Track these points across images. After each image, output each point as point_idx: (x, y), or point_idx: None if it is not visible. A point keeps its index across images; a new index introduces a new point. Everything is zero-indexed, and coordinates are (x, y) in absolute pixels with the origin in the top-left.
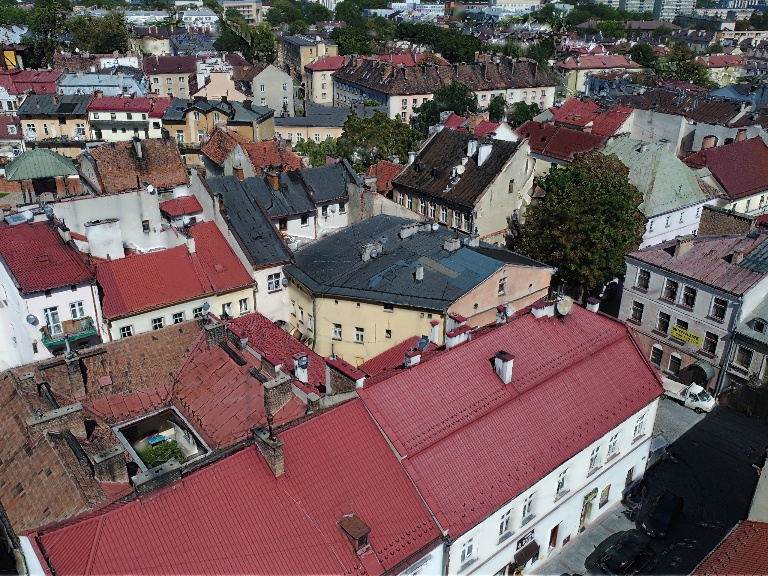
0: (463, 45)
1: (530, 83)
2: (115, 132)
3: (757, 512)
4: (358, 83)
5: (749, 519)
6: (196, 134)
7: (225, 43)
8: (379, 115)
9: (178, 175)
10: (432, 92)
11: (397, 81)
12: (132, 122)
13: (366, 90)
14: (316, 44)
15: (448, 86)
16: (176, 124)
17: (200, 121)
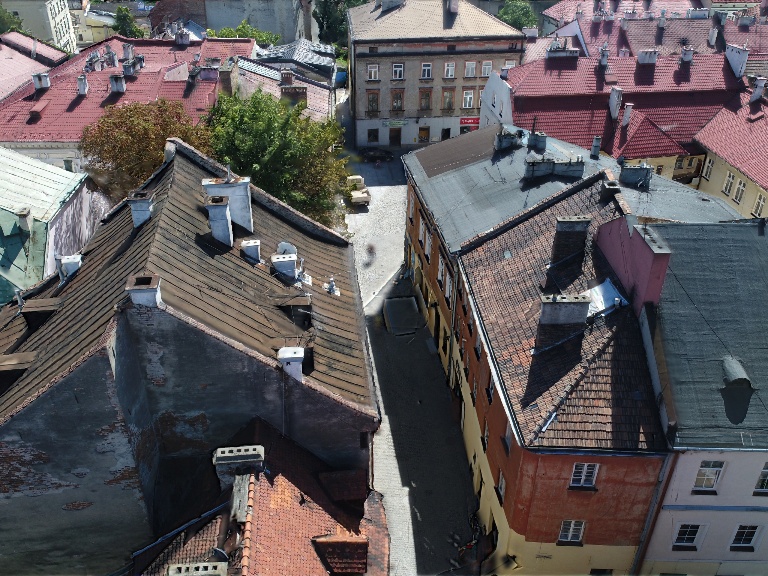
0: None
1: None
2: None
3: None
4: None
5: None
6: None
7: None
8: None
9: None
10: None
11: None
12: None
13: None
14: None
15: None
16: None
17: None
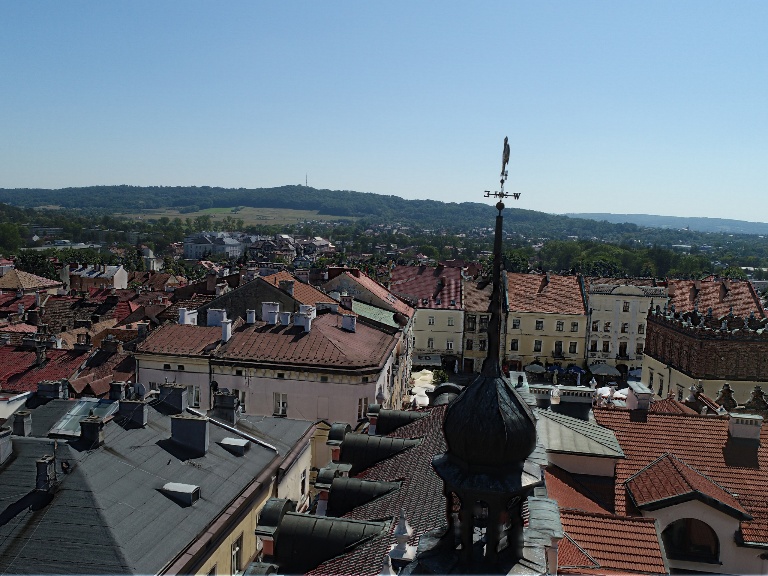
0: None
1: None
2: None
3: None
4: None
5: None
6: None
7: None
8: None
9: None
10: None
11: None
12: None
13: None
14: None
15: None
16: None
17: None
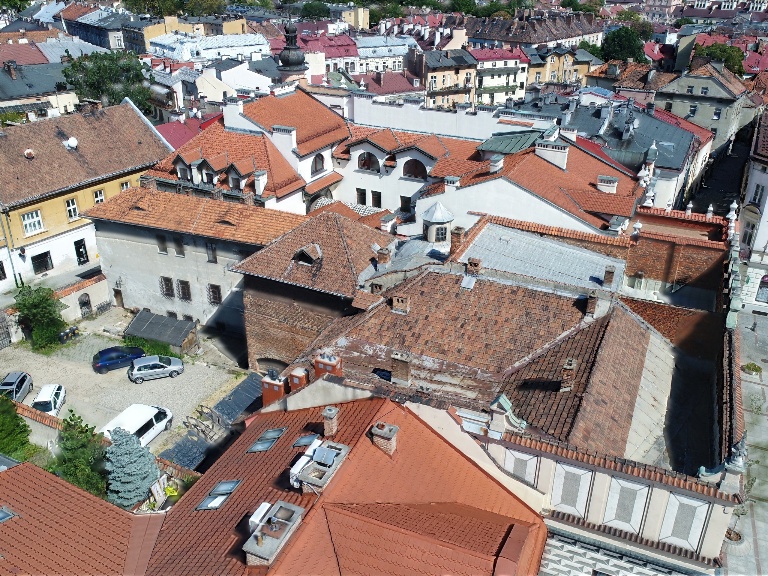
0: (464, 5)
1: (591, 30)
2: (492, 78)
3: None
4: (479, 37)
5: None
6: (550, 74)
7: (314, 10)
8: (720, 45)
9: (740, 84)
10: (552, 40)
11: (530, 32)
12: (508, 68)
13: (492, 42)
14: (354, 9)
15: (618, 31)
16: (537, 67)
17: (555, 63)
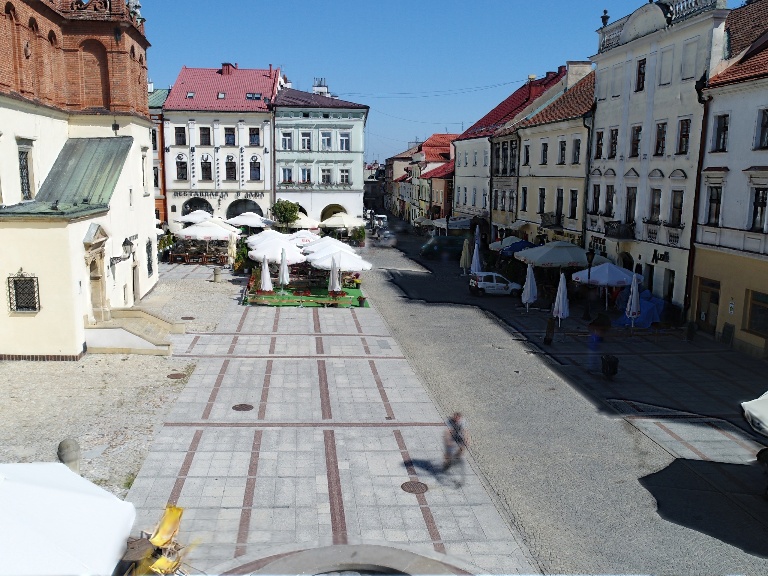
0: None
1: None
2: None
3: (395, 177)
4: None
5: (394, 180)
6: None
7: None
8: None
9: None
10: None
11: None
12: None
13: None
14: None
15: None
16: None
17: None
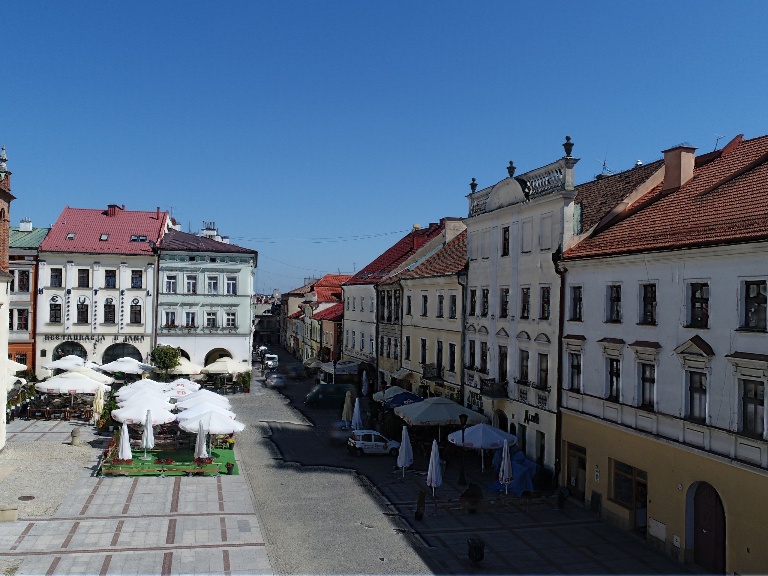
0: None
1: None
2: None
3: (290, 312)
4: None
5: (289, 315)
6: None
7: None
8: None
9: None
10: None
11: None
12: None
13: None
14: None
15: None
16: None
17: None
